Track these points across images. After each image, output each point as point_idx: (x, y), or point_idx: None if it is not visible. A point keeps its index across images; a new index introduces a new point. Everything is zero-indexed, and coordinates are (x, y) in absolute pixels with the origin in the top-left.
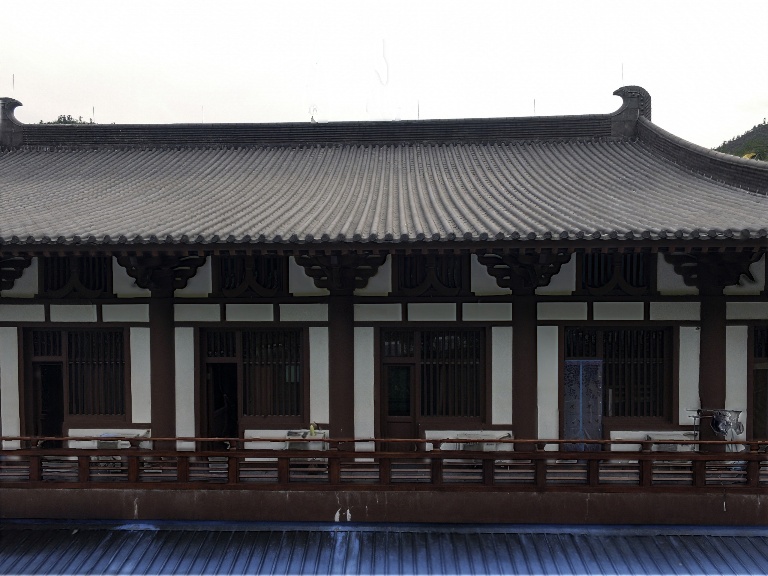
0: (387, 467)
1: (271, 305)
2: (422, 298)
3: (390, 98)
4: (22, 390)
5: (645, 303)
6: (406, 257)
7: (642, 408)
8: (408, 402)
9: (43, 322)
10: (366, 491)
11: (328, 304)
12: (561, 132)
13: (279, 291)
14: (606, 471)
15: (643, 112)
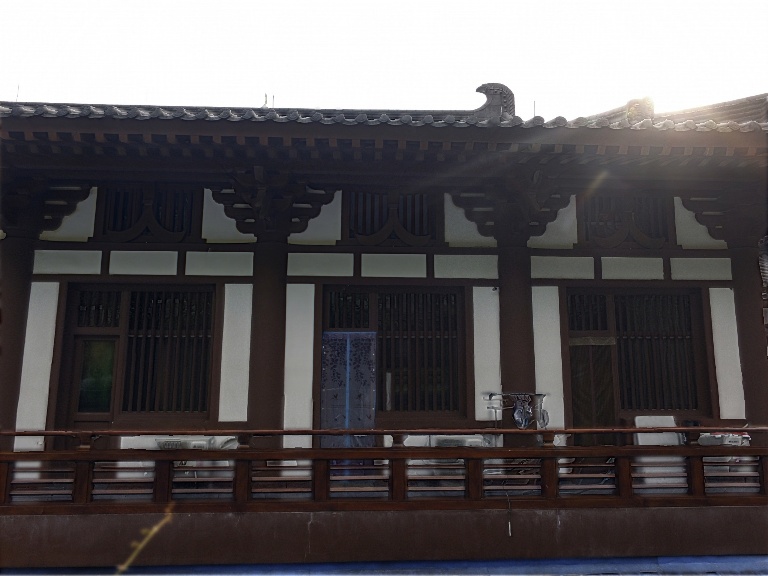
0: (3, 476)
1: None
2: (131, 244)
3: None
4: None
5: (428, 255)
6: (118, 192)
7: (431, 399)
8: (109, 392)
9: None
10: None
11: None
12: None
13: None
14: (341, 477)
15: (506, 109)
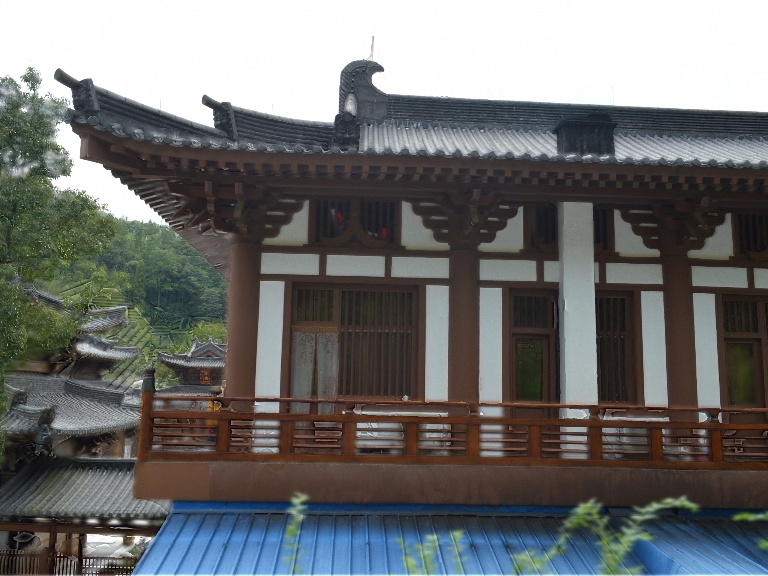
0: None
1: None
2: None
3: None
4: (723, 370)
5: None
6: None
7: None
8: None
9: (747, 288)
10: None
11: None
12: None
13: None
14: None
15: None
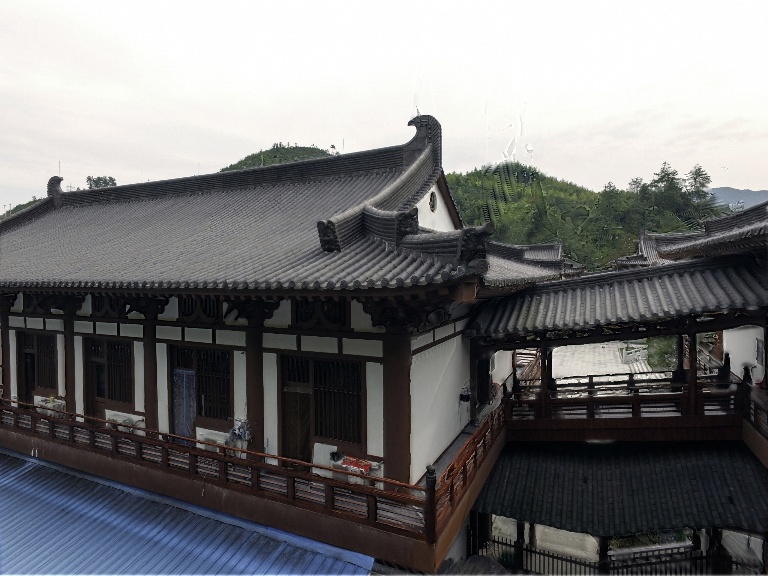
0: (51, 427)
1: (42, 319)
2: (102, 319)
3: (514, 94)
4: None
5: (213, 330)
6: None
7: (221, 413)
8: None
9: None
10: (43, 440)
11: (63, 320)
12: (362, 166)
13: (47, 310)
14: (146, 451)
15: (431, 140)
